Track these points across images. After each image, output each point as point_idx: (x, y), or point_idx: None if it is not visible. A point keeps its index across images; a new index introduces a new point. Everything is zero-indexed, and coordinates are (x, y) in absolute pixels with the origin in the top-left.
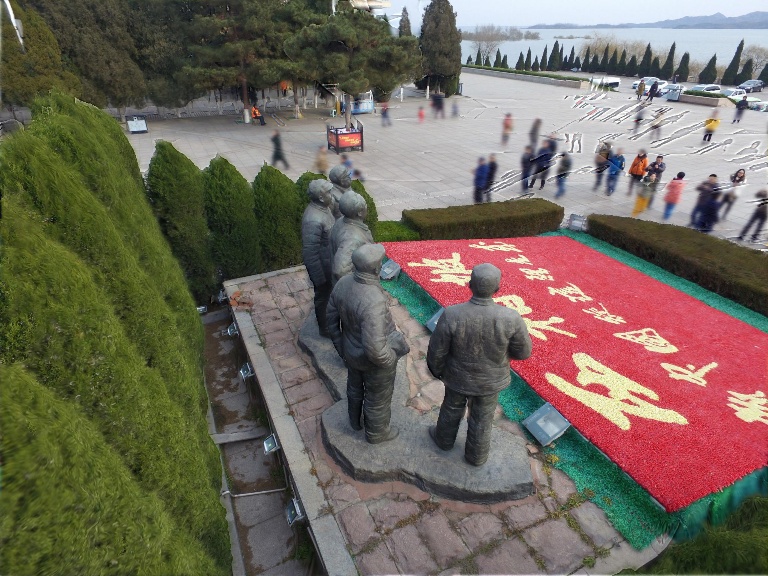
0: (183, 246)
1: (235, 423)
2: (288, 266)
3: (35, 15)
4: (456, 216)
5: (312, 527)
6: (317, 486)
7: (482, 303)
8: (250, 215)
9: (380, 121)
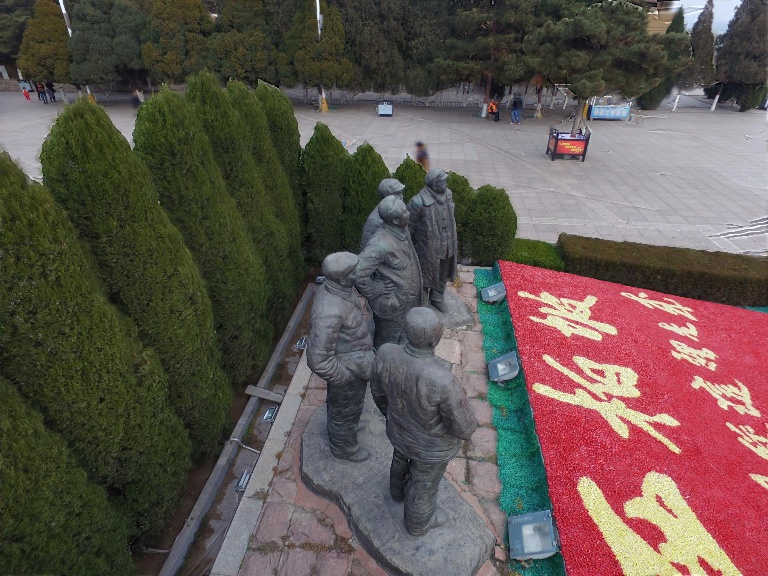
0: (316, 219)
1: (285, 386)
2: None
3: (335, 11)
4: (624, 254)
5: (241, 502)
6: (272, 470)
7: (411, 352)
8: None
9: (628, 131)
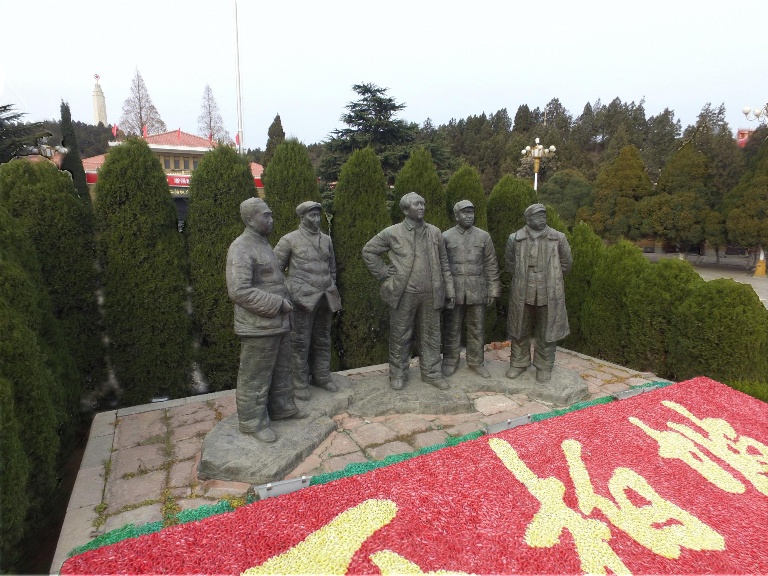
0: None
1: None
2: (599, 358)
3: None
4: None
5: None
6: None
7: None
8: (581, 285)
9: None
